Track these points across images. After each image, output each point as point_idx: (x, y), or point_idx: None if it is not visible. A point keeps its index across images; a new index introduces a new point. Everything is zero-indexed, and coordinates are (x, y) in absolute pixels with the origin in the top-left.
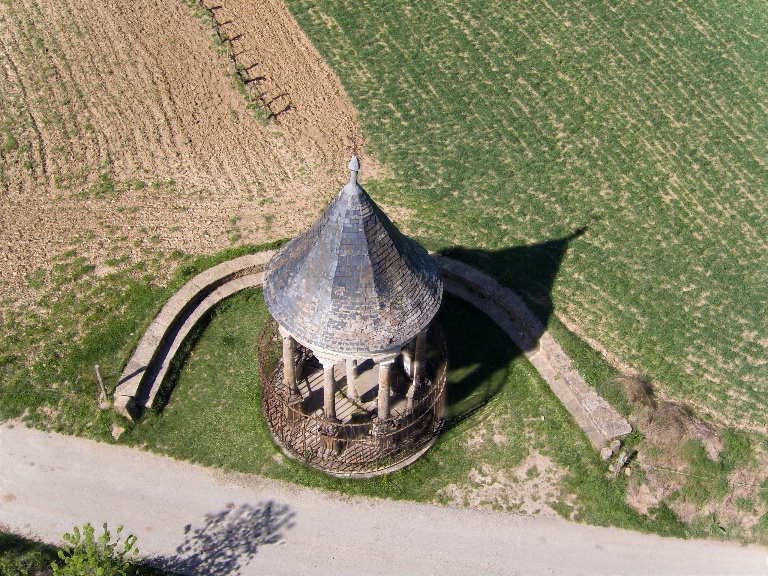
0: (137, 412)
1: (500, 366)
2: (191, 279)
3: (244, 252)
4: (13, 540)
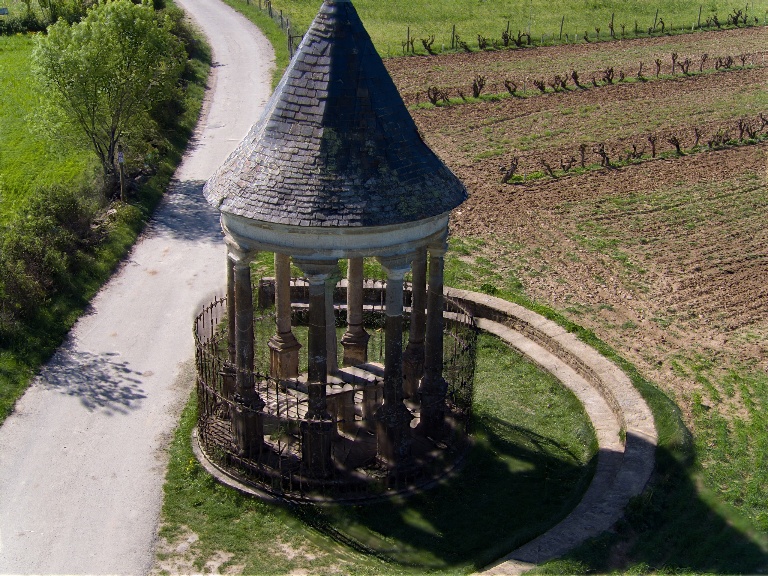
0: (269, 303)
1: (461, 558)
2: None
3: (546, 313)
4: (98, 274)
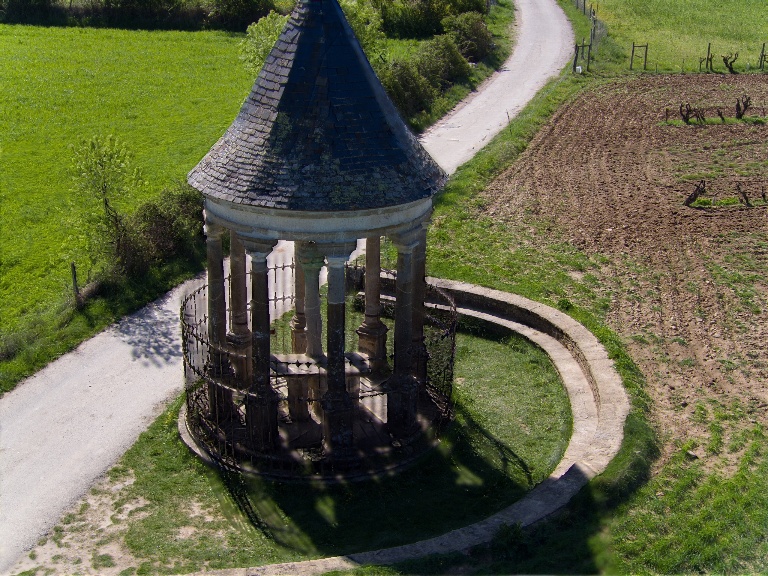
0: (354, 290)
1: (334, 549)
2: (550, 306)
3: None
4: (228, 245)
